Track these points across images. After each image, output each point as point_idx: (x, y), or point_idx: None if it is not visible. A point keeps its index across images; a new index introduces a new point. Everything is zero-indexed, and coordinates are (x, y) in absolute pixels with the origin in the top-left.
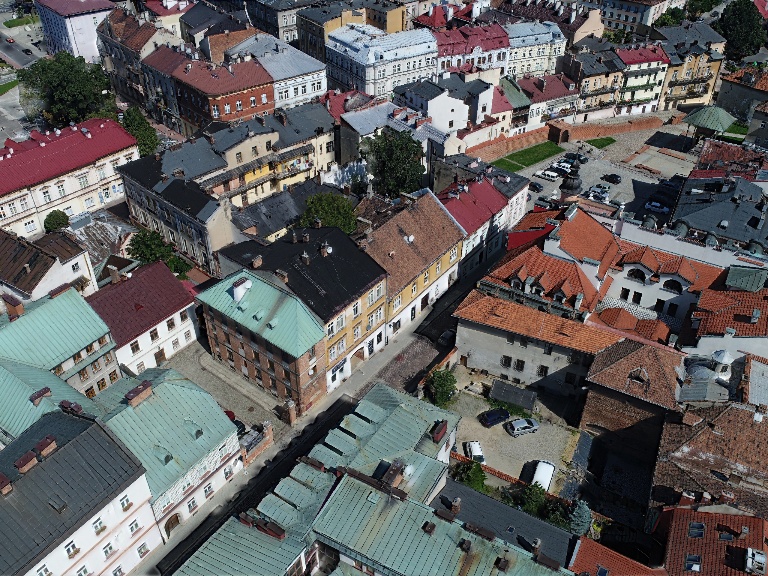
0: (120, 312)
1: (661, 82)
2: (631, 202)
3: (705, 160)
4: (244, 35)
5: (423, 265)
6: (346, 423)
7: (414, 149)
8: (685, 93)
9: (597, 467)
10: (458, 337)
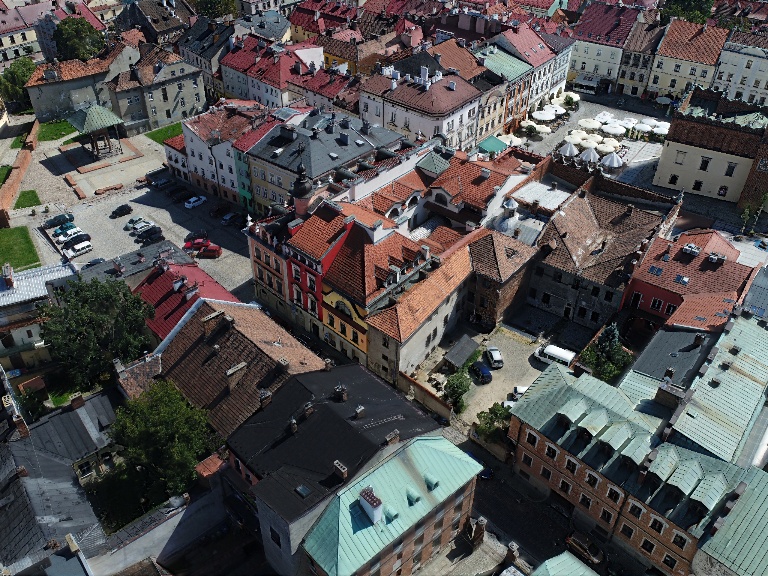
0: None
1: None
2: (171, 214)
3: (205, 137)
4: None
5: (306, 350)
6: (594, 430)
7: (123, 284)
8: None
9: (528, 331)
10: None
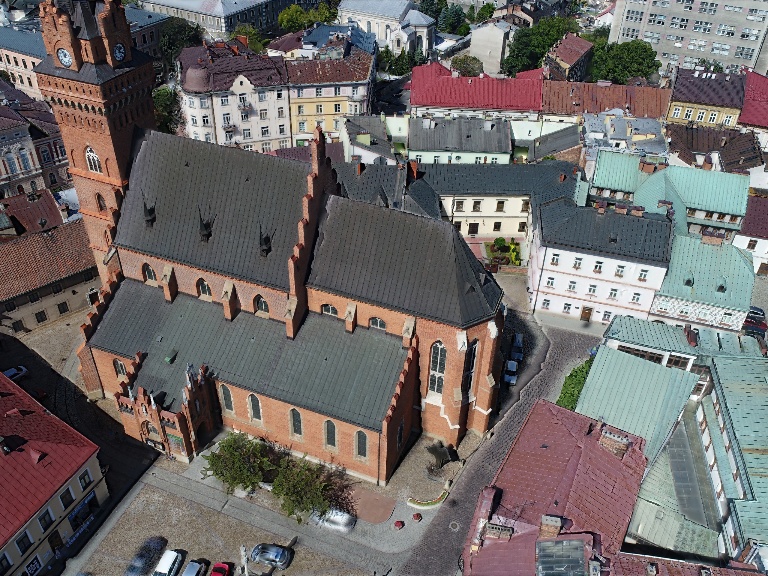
0: (765, 215)
1: None
2: None
3: None
4: None
5: None
6: None
7: None
8: None
9: None
10: None
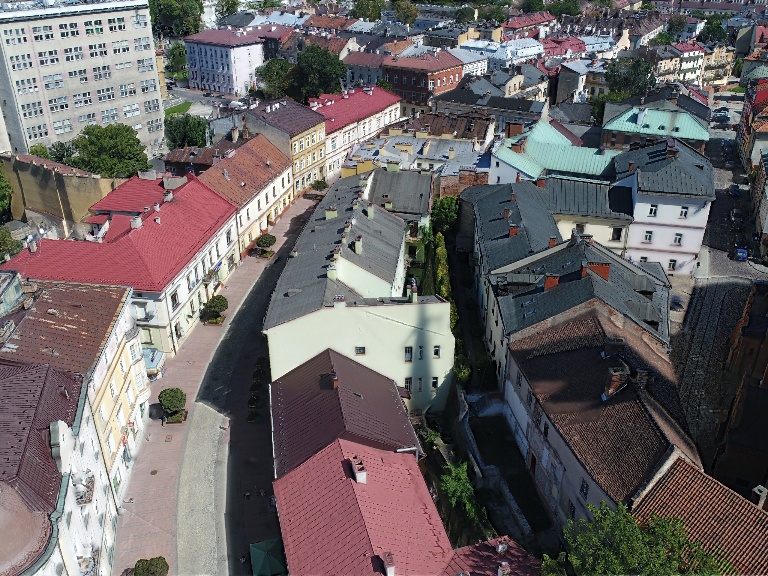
0: None
1: (700, 67)
2: None
3: None
4: (405, 45)
5: None
6: None
7: None
8: (713, 76)
9: None
10: (754, 151)
